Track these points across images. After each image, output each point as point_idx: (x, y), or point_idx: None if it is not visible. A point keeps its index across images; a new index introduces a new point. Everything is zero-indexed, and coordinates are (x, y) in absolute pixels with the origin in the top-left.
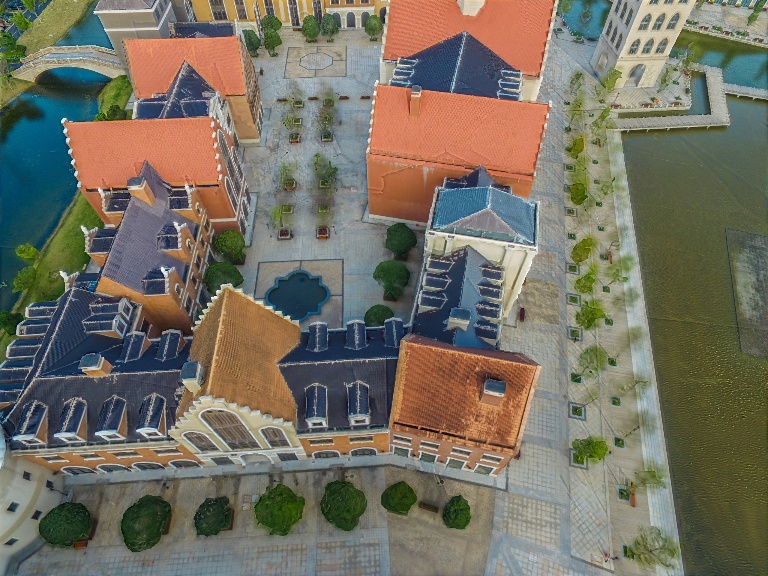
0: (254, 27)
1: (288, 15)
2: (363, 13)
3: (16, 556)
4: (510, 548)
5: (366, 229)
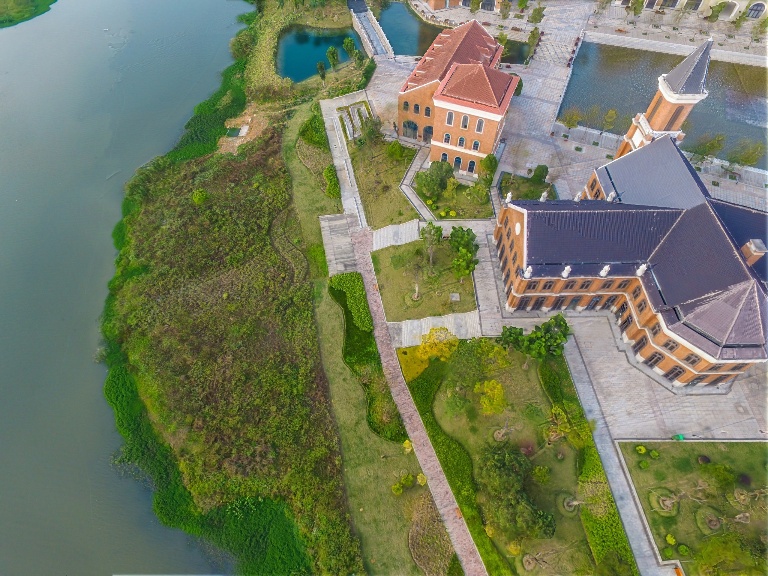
0: None
1: None
2: None
3: None
4: (588, 4)
5: None
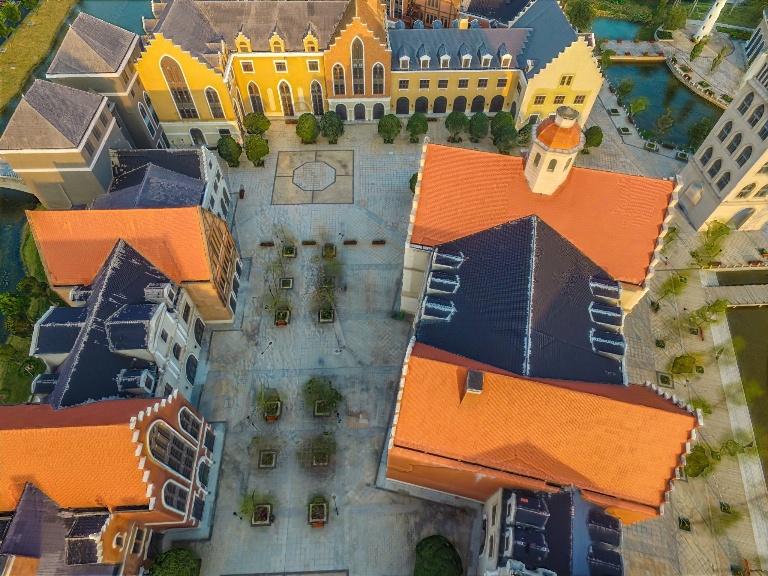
0: (234, 126)
1: (279, 104)
2: (376, 104)
3: None
4: None
5: (382, 503)
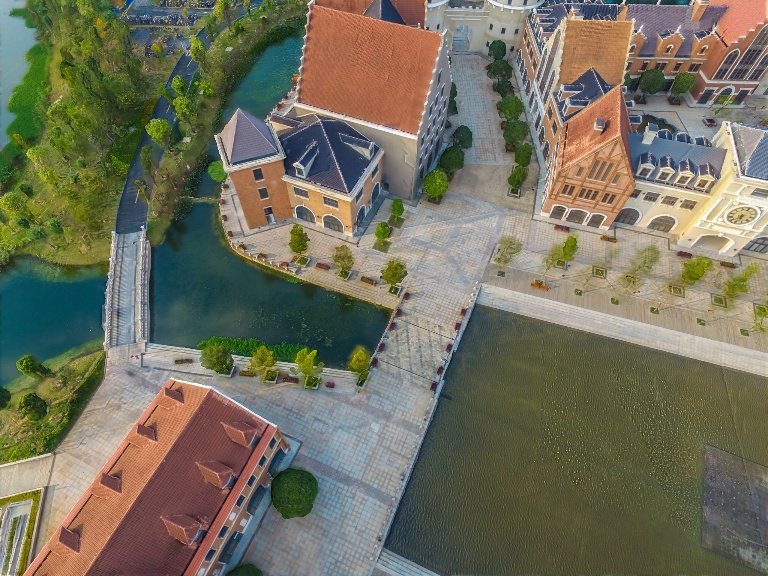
0: None
1: None
2: None
3: (481, 53)
4: (499, 215)
5: None
